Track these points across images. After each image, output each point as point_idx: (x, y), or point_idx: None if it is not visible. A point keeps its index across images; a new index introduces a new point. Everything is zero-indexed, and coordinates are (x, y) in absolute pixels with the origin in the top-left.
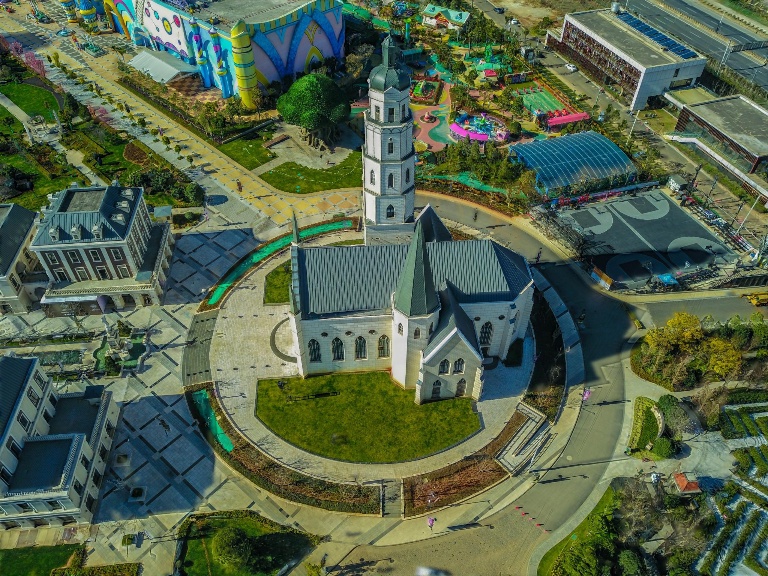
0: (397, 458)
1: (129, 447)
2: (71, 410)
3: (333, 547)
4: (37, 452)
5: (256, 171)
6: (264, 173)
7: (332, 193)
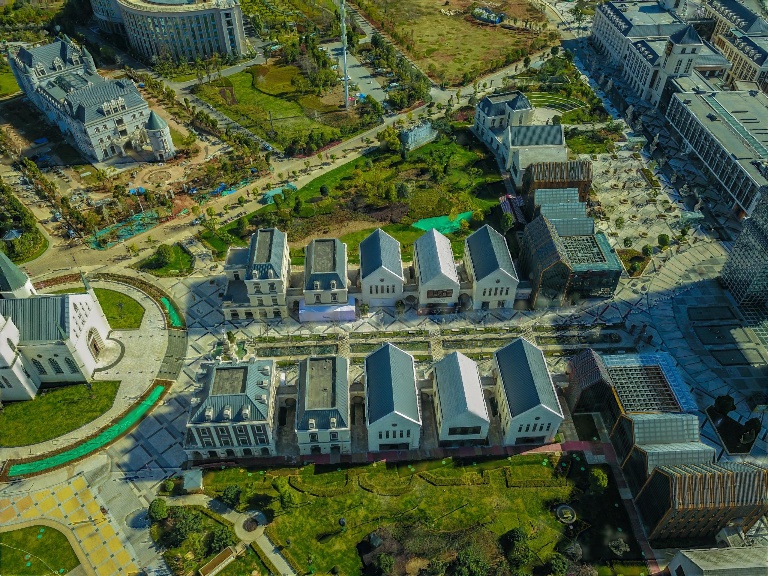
0: (76, 289)
1: (219, 302)
2: (244, 300)
3: (124, 265)
4: (246, 263)
5: (79, 575)
6: (71, 570)
7: (6, 525)
